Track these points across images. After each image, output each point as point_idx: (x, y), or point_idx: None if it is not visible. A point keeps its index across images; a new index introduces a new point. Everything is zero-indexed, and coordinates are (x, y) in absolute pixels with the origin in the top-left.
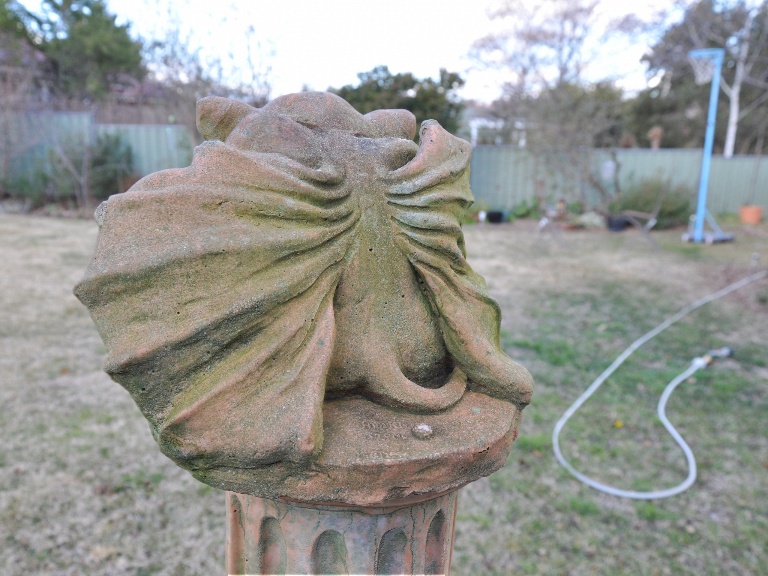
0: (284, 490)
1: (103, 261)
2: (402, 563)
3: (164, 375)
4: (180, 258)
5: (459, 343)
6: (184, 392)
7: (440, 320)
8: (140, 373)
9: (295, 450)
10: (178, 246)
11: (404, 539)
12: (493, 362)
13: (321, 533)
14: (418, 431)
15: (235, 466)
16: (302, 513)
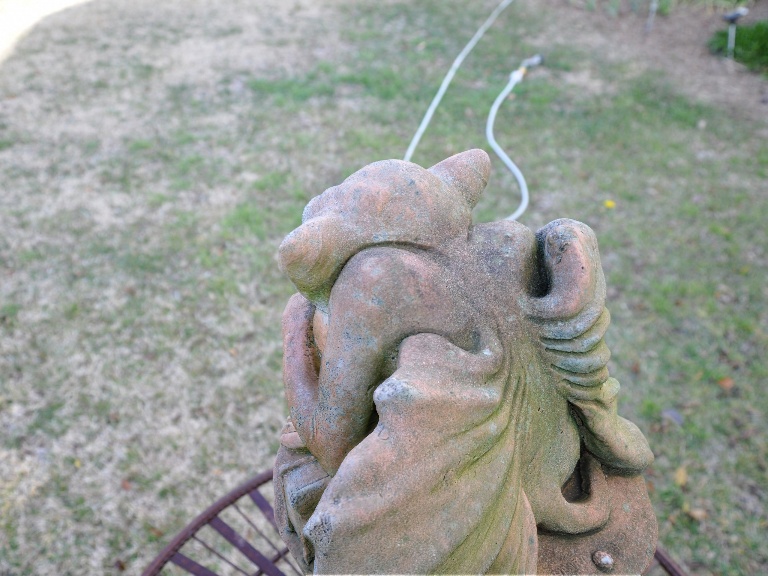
0: None
1: None
2: None
3: None
4: (433, 569)
5: (602, 447)
6: None
7: (582, 428)
8: None
9: None
10: (427, 557)
11: None
12: (631, 454)
13: None
14: (604, 567)
15: None
16: None
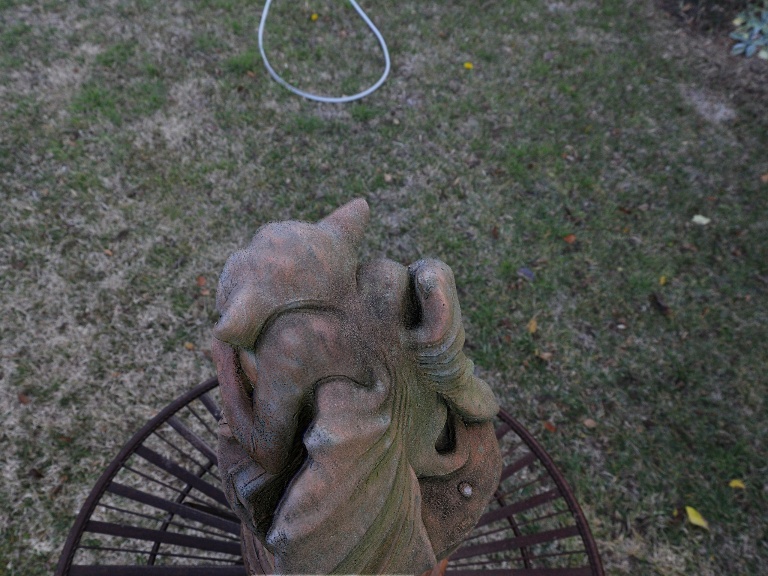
0: None
1: (300, 573)
2: None
3: None
4: None
5: None
6: None
7: (448, 400)
8: None
9: None
10: (351, 539)
11: None
12: (483, 410)
13: None
14: (466, 494)
15: None
16: None
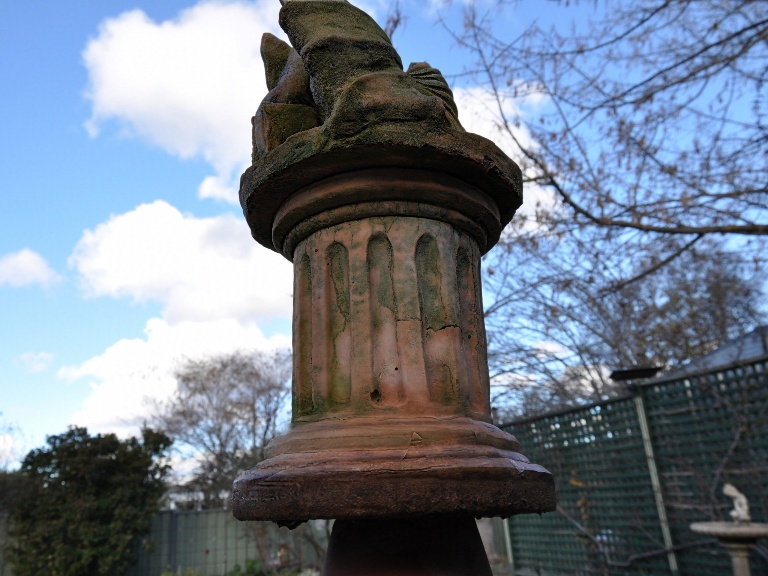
0: (427, 140)
1: None
2: (468, 285)
3: (347, 59)
4: (350, 5)
5: None
6: (356, 76)
7: None
8: (335, 51)
9: (436, 107)
10: None
11: (467, 265)
12: None
13: (420, 236)
14: None
15: (397, 117)
16: (405, 221)
